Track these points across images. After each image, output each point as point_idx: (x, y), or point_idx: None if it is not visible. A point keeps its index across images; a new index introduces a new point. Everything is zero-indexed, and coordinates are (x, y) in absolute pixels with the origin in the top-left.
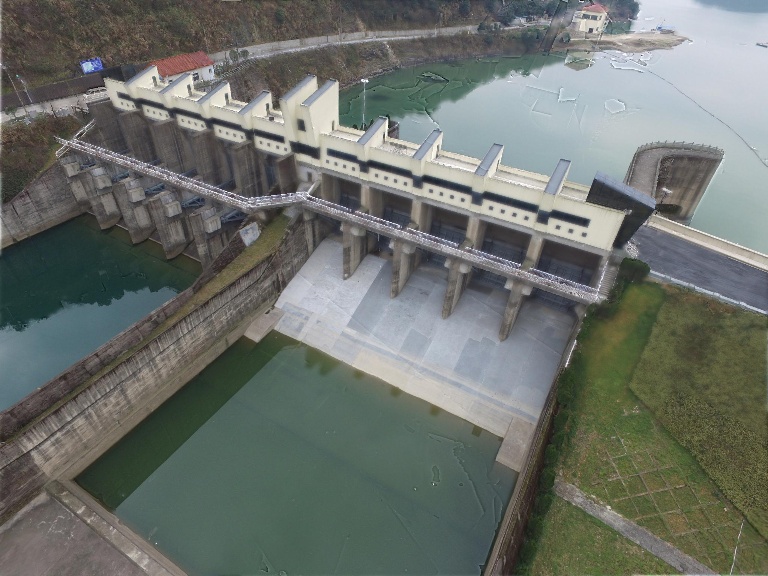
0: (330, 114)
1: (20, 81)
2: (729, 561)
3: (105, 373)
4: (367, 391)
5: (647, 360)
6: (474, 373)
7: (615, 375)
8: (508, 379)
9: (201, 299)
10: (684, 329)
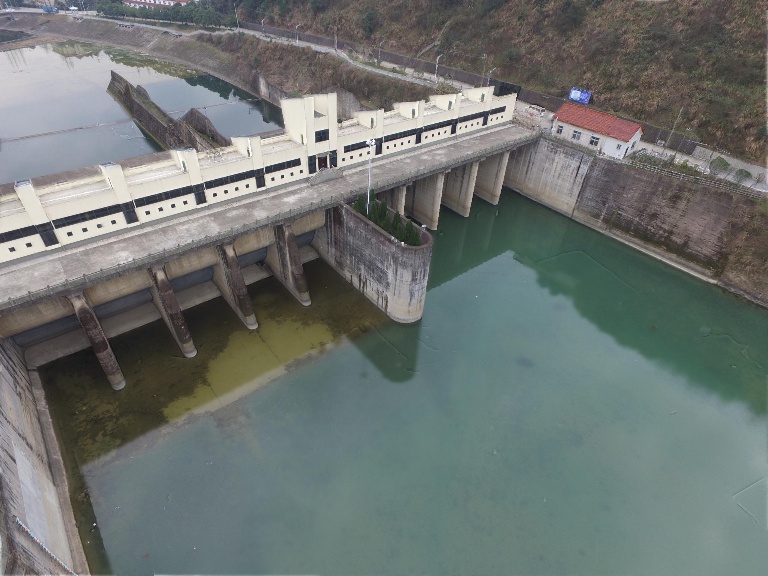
0: (299, 125)
1: (531, 82)
2: None
3: (210, 142)
4: None
5: None
6: None
7: None
8: None
9: None
10: None
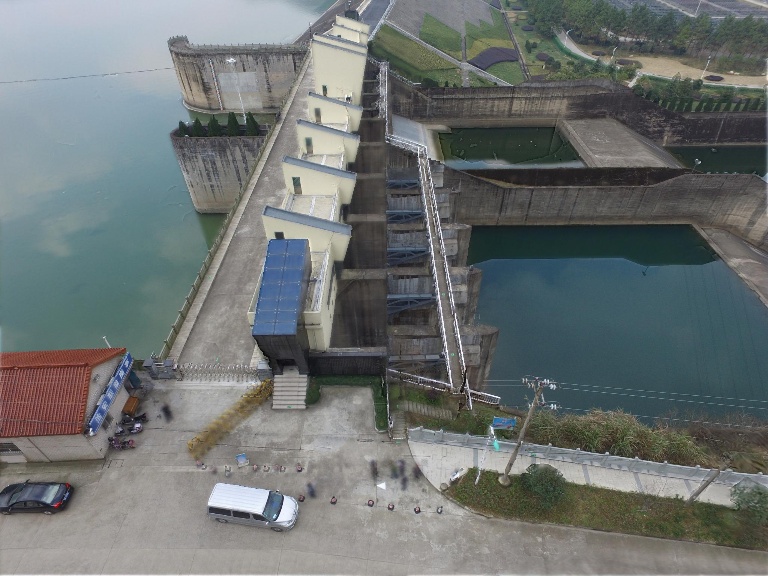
0: None
1: None
2: (458, 77)
3: None
4: (457, 166)
5: (409, 62)
6: (415, 136)
7: (417, 74)
8: (410, 128)
9: (504, 186)
10: (392, 49)
